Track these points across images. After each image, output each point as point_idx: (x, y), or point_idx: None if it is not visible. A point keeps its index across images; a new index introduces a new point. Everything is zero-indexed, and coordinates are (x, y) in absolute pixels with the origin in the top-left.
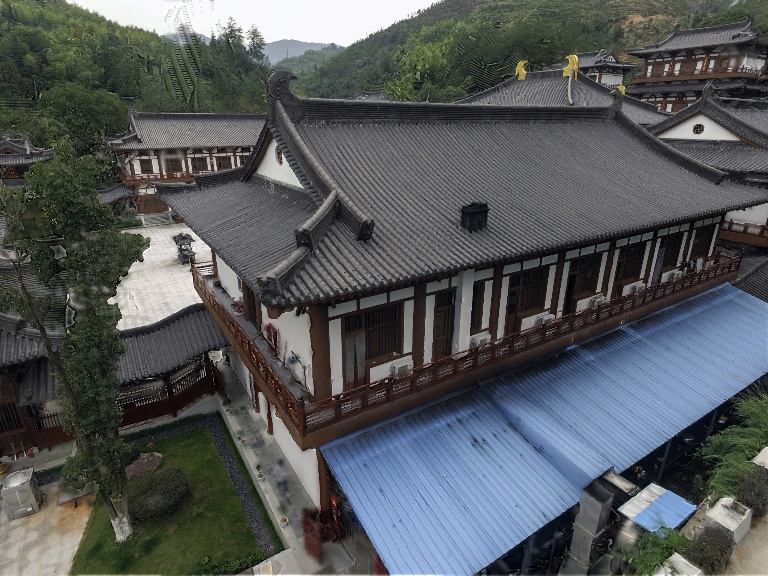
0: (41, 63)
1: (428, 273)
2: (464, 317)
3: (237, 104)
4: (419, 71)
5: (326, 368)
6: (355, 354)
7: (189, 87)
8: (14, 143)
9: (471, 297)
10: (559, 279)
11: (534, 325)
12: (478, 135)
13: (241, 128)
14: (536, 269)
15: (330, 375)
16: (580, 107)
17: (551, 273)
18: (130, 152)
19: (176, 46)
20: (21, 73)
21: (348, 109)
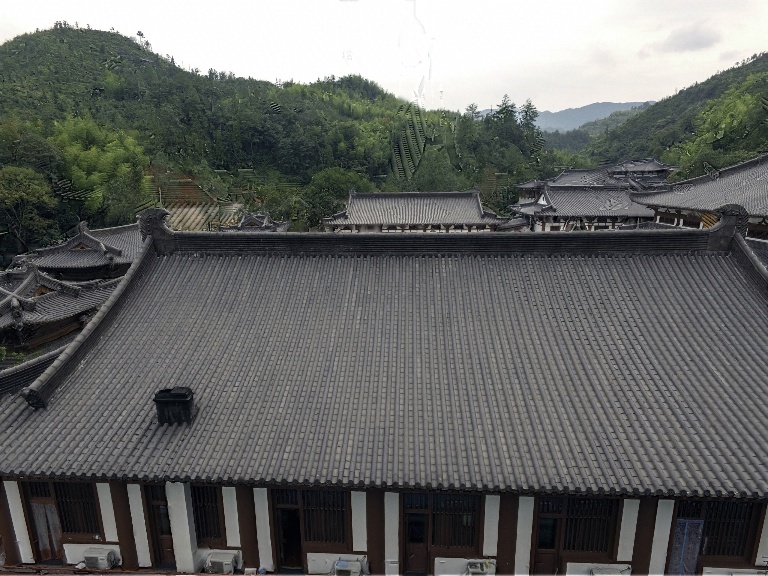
0: (349, 148)
1: (10, 473)
2: (177, 525)
3: (440, 184)
4: (722, 130)
5: (5, 527)
6: (48, 522)
7: (411, 168)
8: (259, 218)
9: (184, 503)
10: (374, 514)
11: (331, 568)
12: (393, 273)
13: (439, 206)
14: (321, 489)
15: (15, 535)
16: (629, 232)
17: (356, 502)
18: (336, 226)
19: (404, 134)
20: (335, 156)
21: (224, 241)
